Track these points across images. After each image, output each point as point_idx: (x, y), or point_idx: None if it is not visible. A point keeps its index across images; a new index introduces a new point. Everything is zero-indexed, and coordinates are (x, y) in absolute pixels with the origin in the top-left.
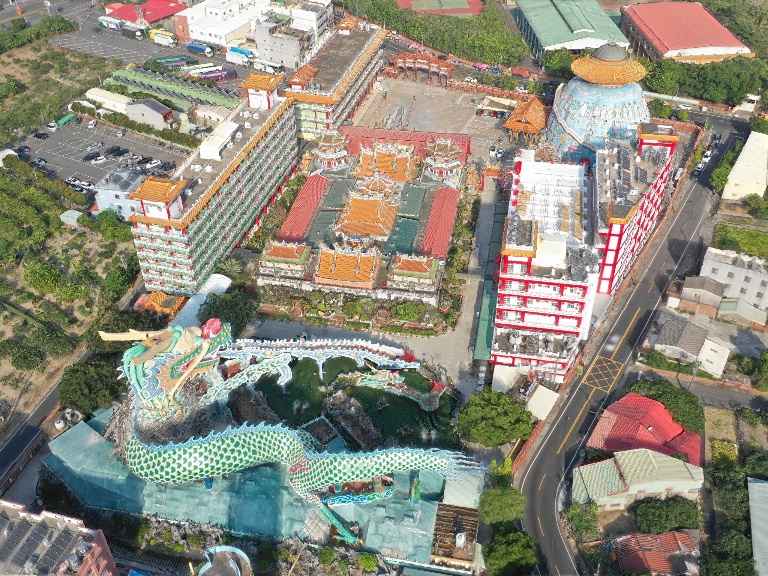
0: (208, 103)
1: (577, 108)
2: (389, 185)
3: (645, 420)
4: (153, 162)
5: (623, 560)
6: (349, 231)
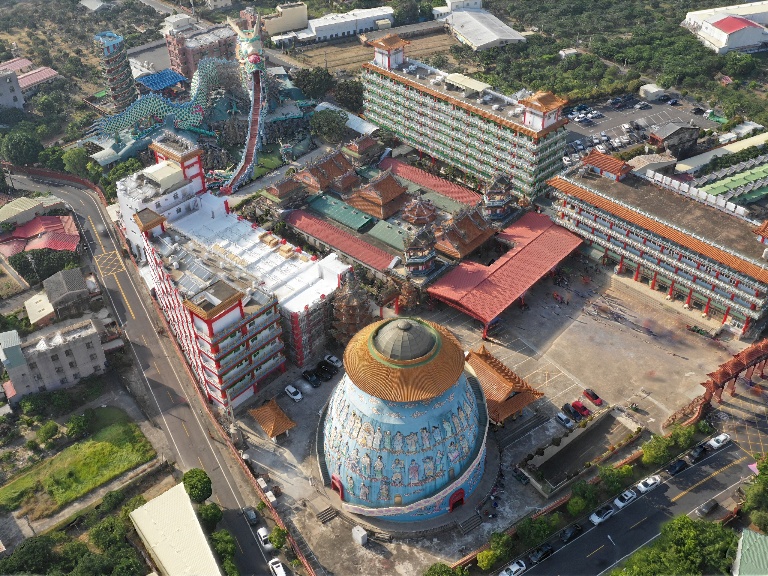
0: (705, 181)
1: None
2: (415, 217)
3: None
4: (600, 146)
5: (7, 195)
6: None
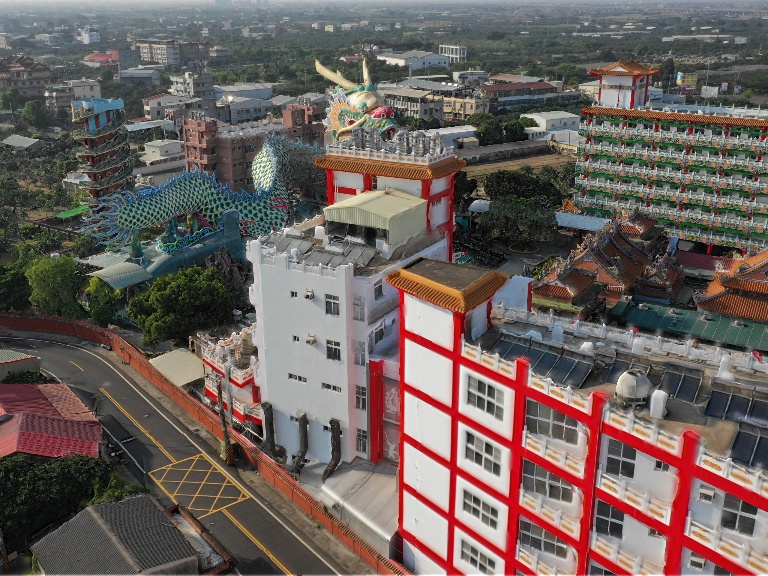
0: None
1: None
2: None
3: (11, 425)
4: None
5: None
6: (715, 281)
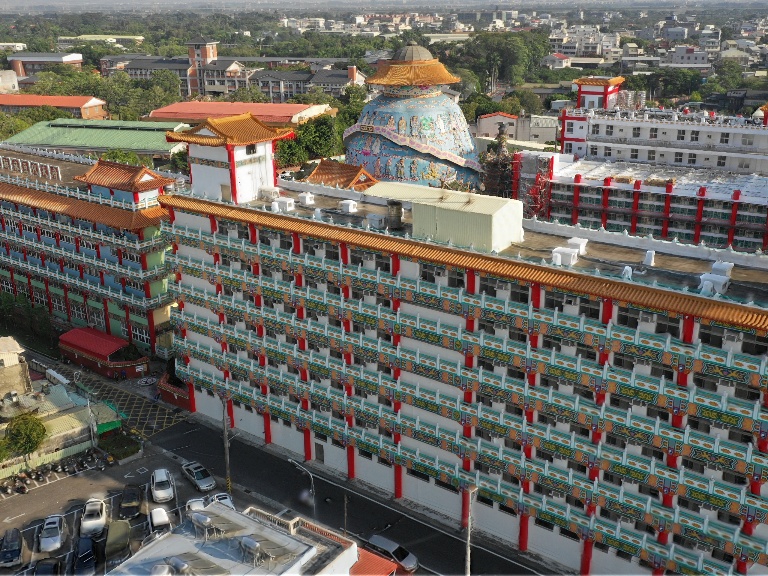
0: None
1: (433, 126)
2: None
3: None
4: None
5: None
6: None
